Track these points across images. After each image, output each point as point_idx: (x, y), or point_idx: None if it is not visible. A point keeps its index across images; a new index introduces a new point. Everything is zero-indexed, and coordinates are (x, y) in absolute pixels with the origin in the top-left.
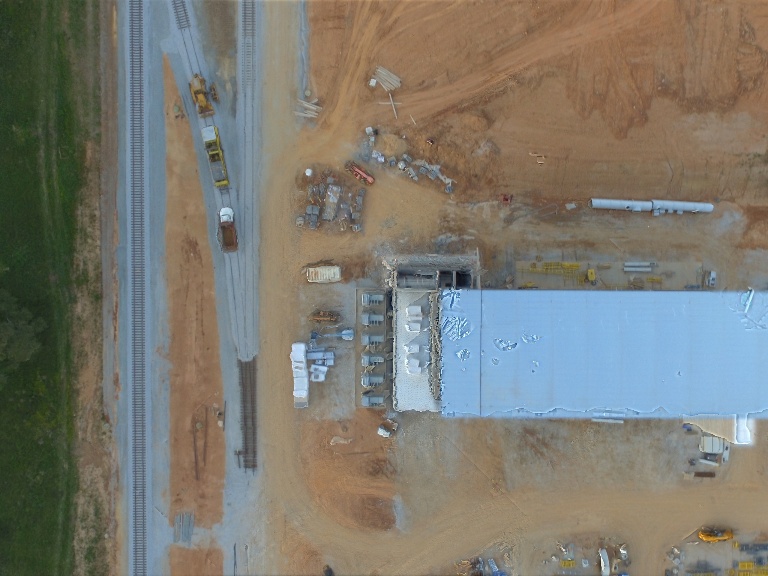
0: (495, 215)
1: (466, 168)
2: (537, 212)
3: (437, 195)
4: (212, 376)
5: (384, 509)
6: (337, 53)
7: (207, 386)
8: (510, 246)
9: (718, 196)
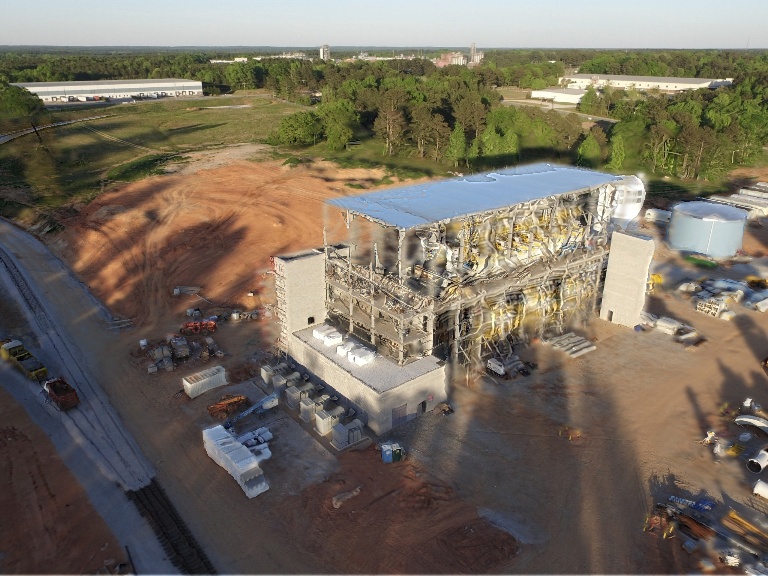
0: None
1: None
2: None
3: None
4: (86, 532)
5: (483, 534)
6: (134, 293)
7: (81, 548)
8: None
9: None
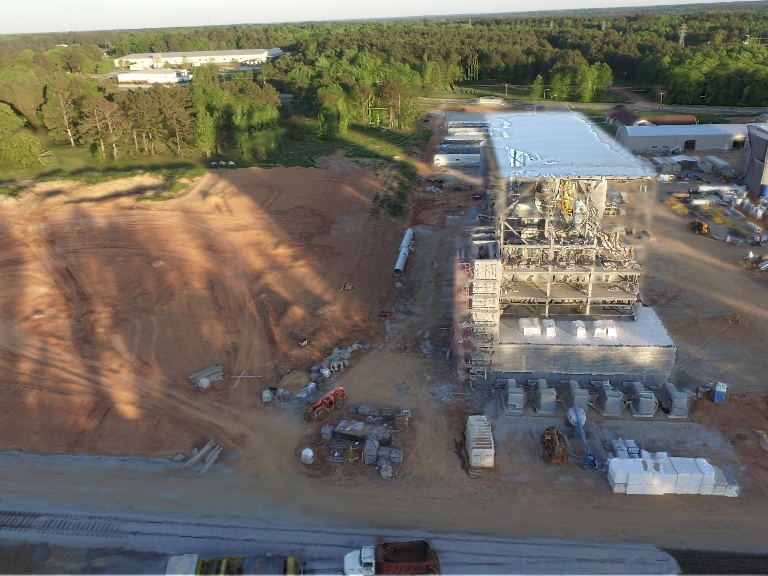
0: (402, 321)
1: (343, 331)
2: (402, 299)
3: (371, 355)
4: None
5: None
6: (142, 415)
7: None
8: (439, 312)
9: (401, 233)
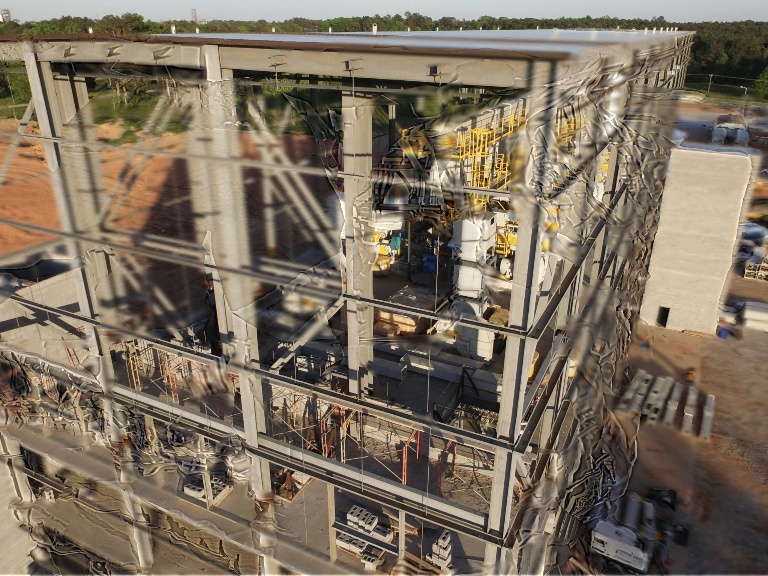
0: None
1: None
2: None
3: None
4: None
5: None
6: None
7: None
8: None
9: None
